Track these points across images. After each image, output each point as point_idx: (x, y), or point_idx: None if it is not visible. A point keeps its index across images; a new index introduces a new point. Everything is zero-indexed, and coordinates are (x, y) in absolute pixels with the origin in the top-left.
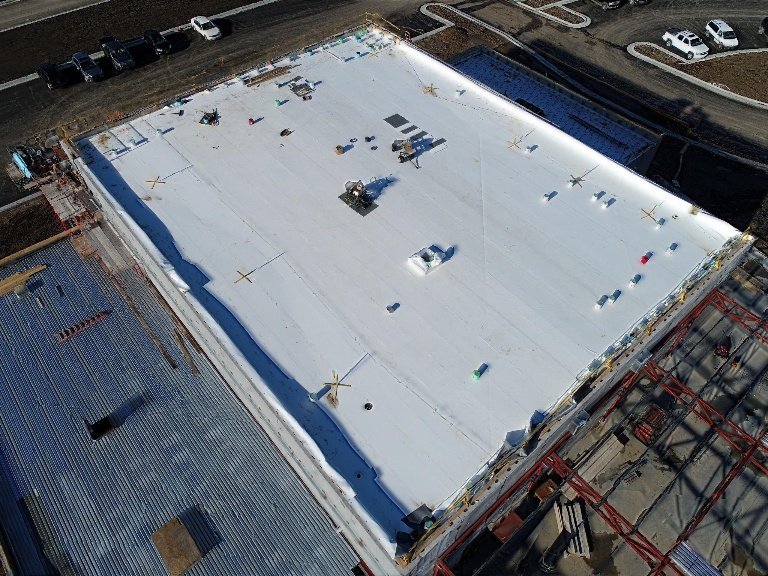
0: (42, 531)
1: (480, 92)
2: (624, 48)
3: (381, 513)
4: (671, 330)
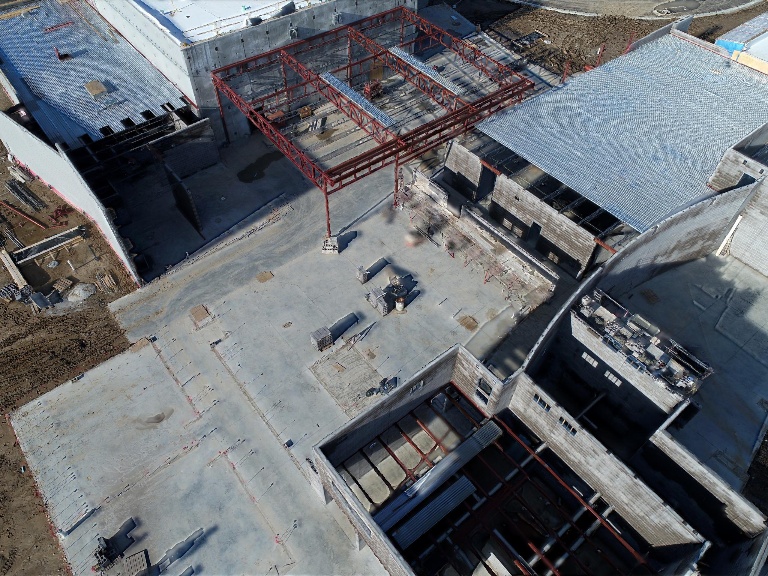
0: (31, 86)
1: None
2: None
3: None
4: (367, 17)
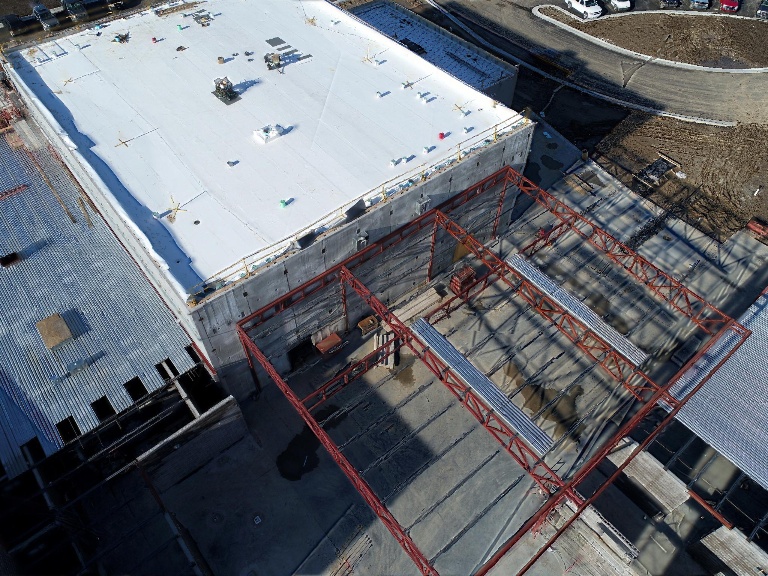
0: None
1: (351, 22)
2: (529, 9)
3: (188, 282)
4: (462, 192)
